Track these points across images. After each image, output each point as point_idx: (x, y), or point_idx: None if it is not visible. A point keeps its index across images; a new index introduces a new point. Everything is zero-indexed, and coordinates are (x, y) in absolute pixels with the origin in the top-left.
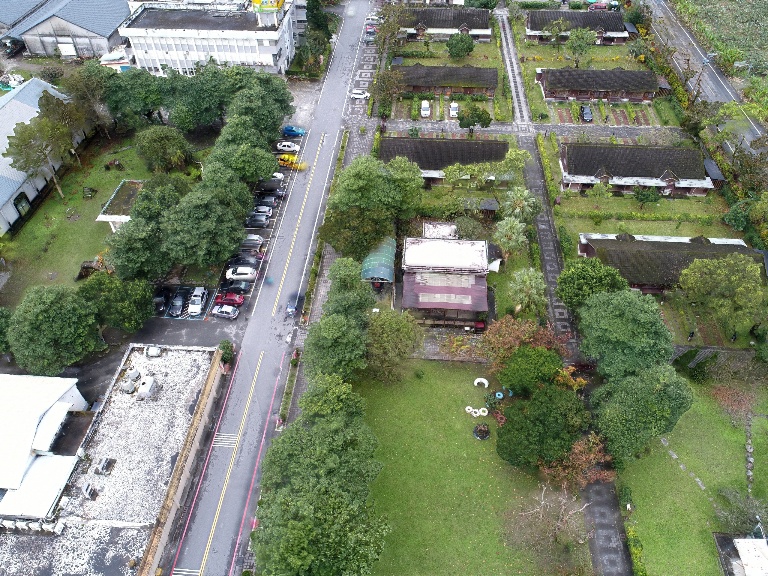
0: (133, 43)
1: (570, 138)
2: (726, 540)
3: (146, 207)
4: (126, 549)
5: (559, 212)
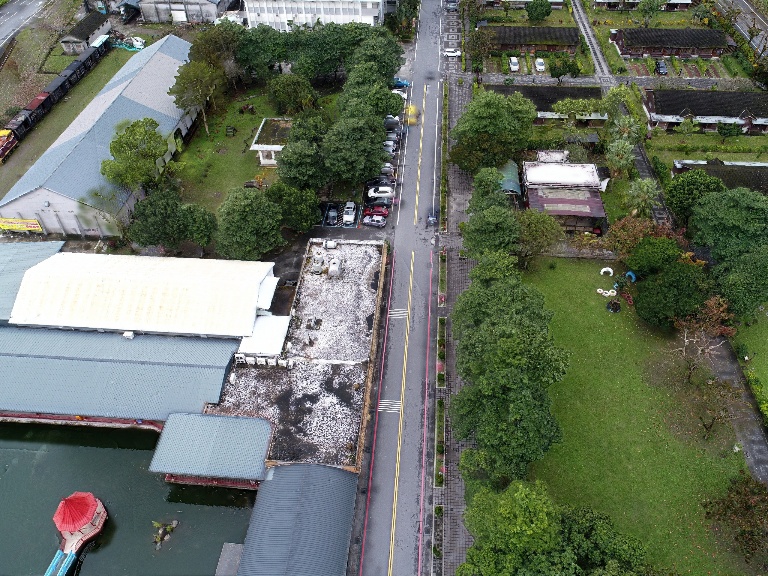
0: (248, 7)
1: (653, 85)
2: None
3: (303, 133)
4: (348, 378)
5: (651, 145)
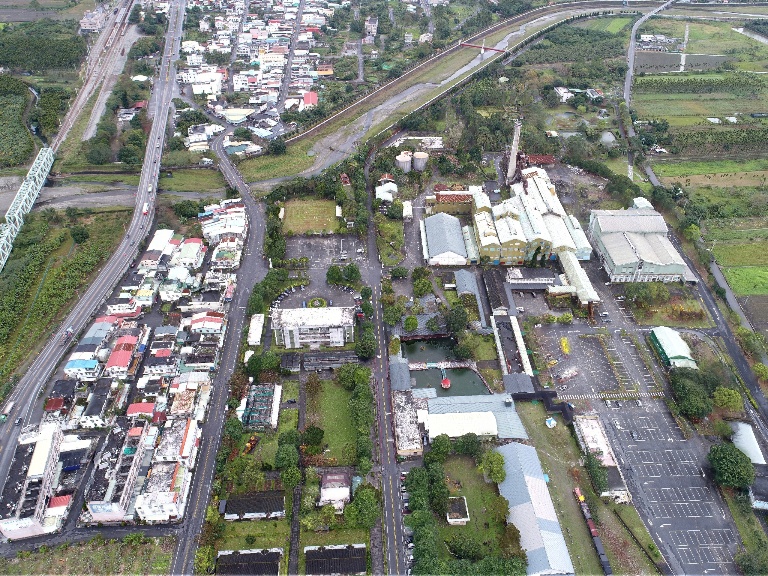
0: None
1: None
2: None
3: None
4: None
5: None
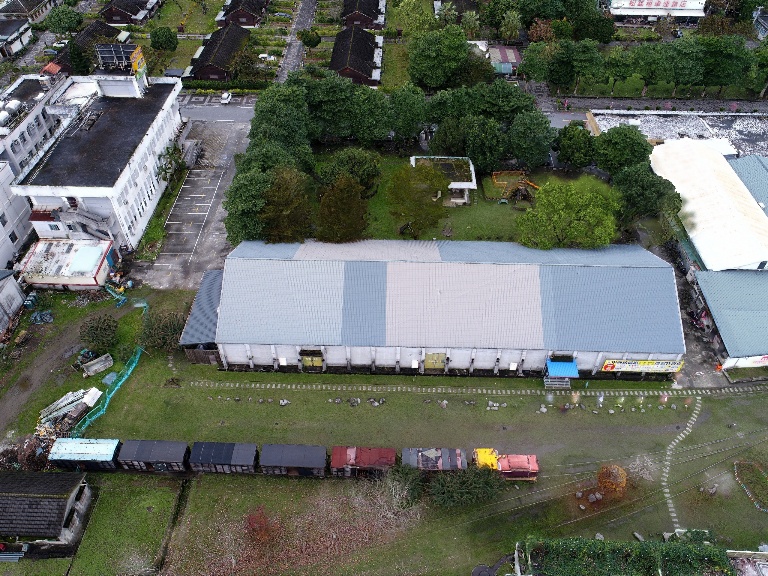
0: (116, 202)
1: (335, 15)
2: None
3: None
4: None
5: None
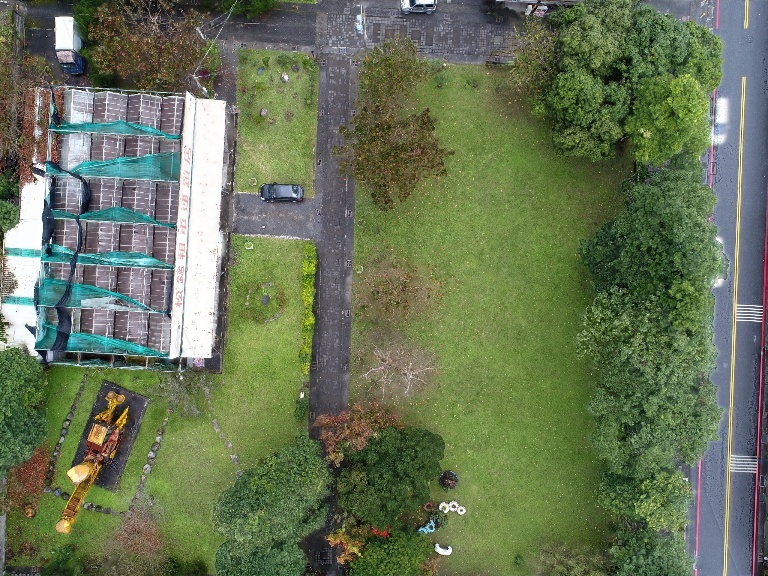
0: None
1: None
2: (211, 366)
3: None
4: None
5: None
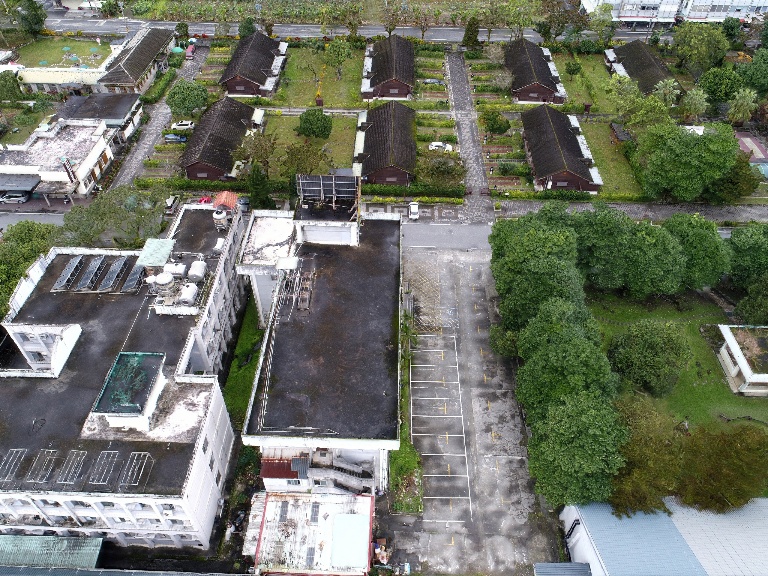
0: None
1: (506, 85)
2: None
3: None
4: None
5: (599, 107)
